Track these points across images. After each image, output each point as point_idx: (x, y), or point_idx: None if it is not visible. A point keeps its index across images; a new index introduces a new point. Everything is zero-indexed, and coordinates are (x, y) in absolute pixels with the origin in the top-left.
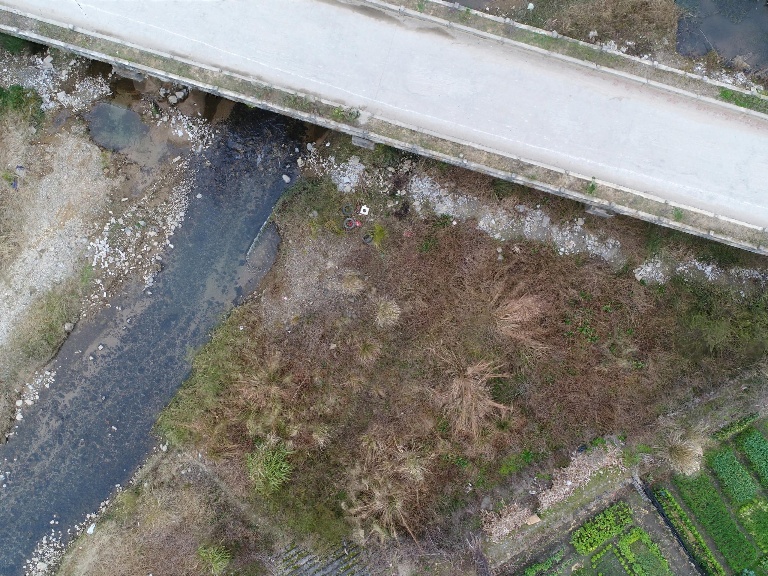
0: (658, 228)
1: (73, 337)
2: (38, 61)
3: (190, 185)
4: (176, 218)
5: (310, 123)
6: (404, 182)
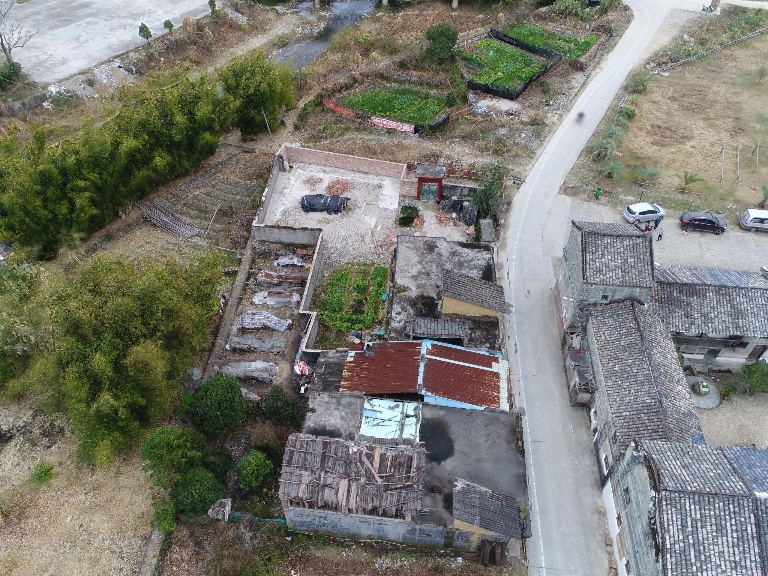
0: (477, 6)
1: (289, 44)
2: (278, 6)
3: (327, 21)
4: (323, 25)
5: (364, 12)
6: (397, 14)
